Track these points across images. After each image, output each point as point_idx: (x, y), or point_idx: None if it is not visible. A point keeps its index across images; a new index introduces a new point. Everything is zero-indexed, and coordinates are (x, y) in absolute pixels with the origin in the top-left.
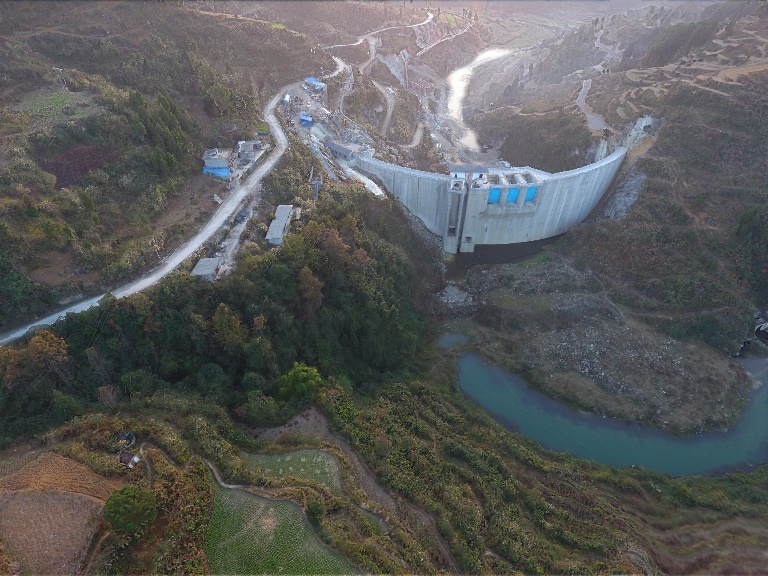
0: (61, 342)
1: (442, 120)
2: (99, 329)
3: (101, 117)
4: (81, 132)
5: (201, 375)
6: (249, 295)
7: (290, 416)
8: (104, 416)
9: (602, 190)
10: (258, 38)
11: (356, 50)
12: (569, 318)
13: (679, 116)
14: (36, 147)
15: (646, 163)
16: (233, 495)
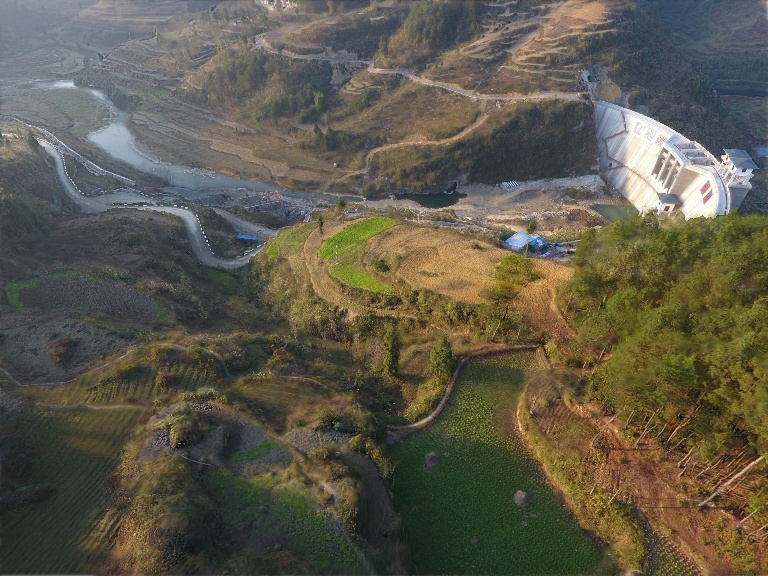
0: None
1: None
2: None
3: None
4: None
5: None
6: None
7: None
8: None
9: None
10: None
11: (213, 214)
12: None
13: (615, 57)
14: None
15: (637, 97)
16: None
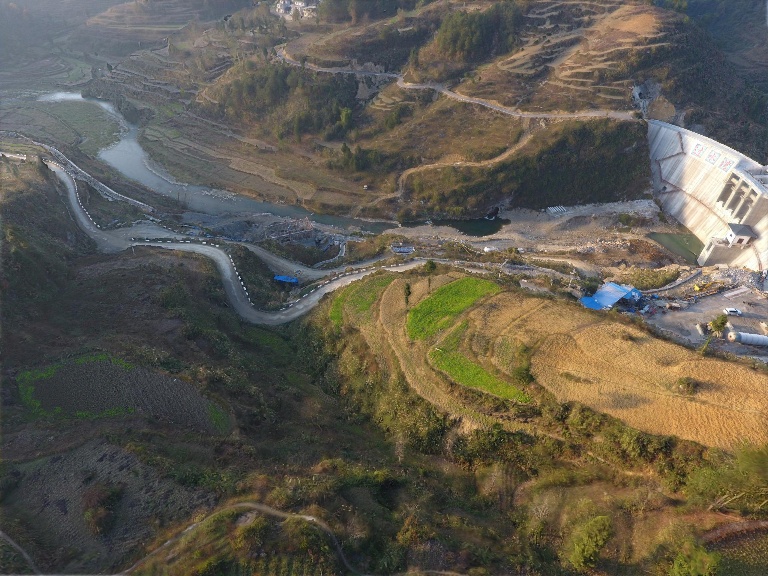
0: None
1: None
2: None
3: None
4: None
5: None
6: None
7: None
8: None
9: None
10: None
11: (248, 253)
12: None
13: (669, 72)
14: None
15: (693, 116)
16: None
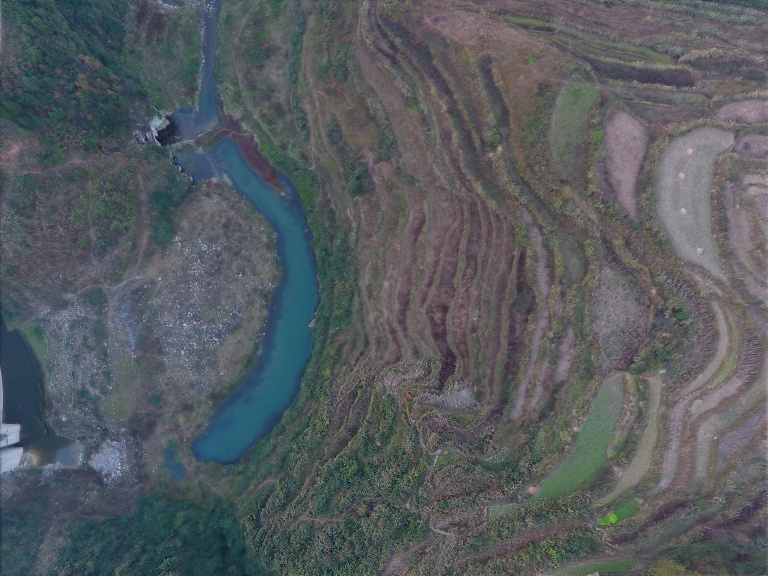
0: None
1: None
2: None
3: None
4: None
5: None
6: None
7: None
8: None
9: None
10: None
11: None
12: (147, 340)
13: None
14: None
15: None
16: None
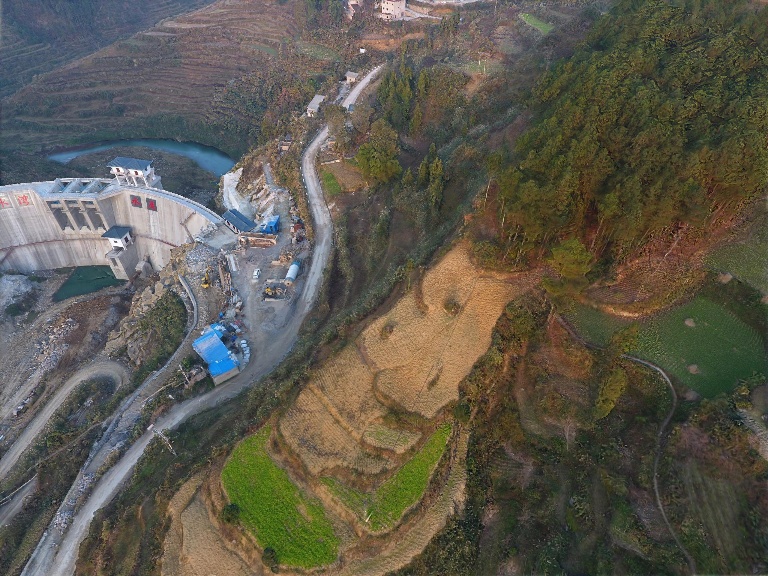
0: None
1: None
2: None
3: None
4: None
5: None
6: None
7: None
8: None
9: None
10: None
11: None
12: None
13: None
14: None
15: None
16: None
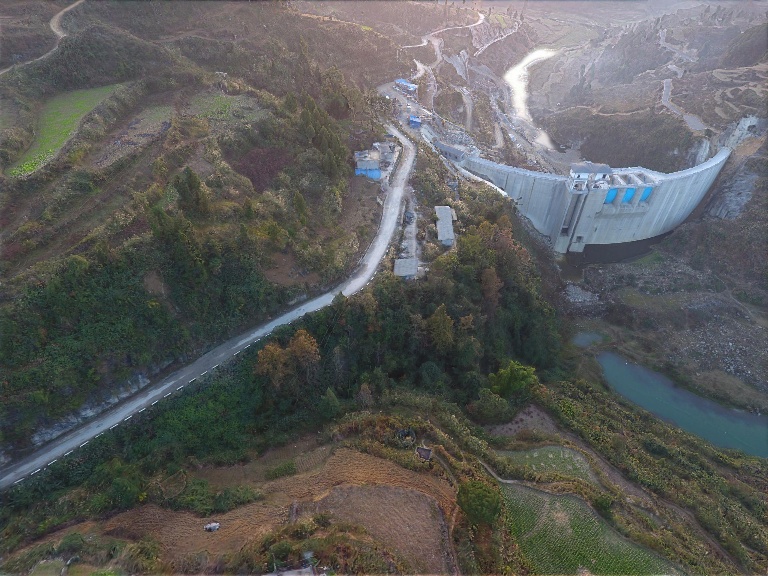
0: (315, 341)
1: (512, 120)
2: (331, 329)
3: (270, 120)
4: (255, 135)
5: (426, 373)
6: (448, 295)
7: (514, 413)
8: (370, 413)
9: (706, 190)
10: (351, 40)
11: (425, 51)
12: (701, 317)
13: None
14: (223, 150)
15: (758, 163)
16: (514, 490)
